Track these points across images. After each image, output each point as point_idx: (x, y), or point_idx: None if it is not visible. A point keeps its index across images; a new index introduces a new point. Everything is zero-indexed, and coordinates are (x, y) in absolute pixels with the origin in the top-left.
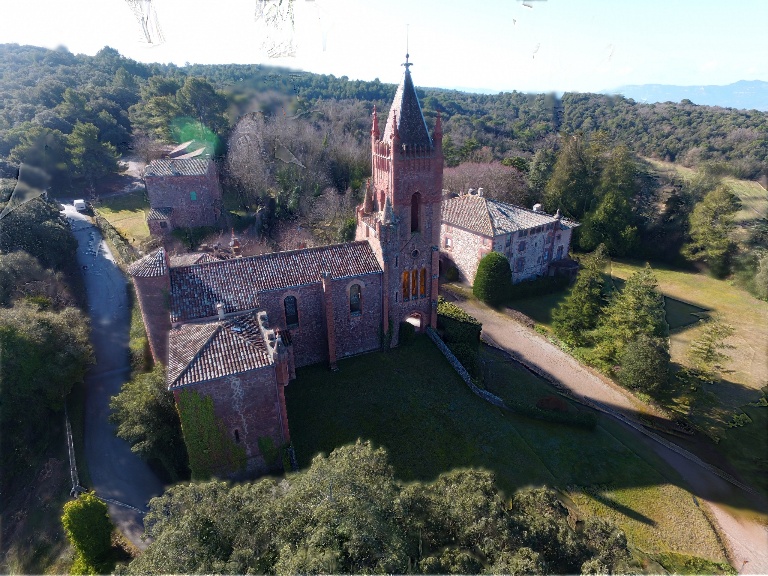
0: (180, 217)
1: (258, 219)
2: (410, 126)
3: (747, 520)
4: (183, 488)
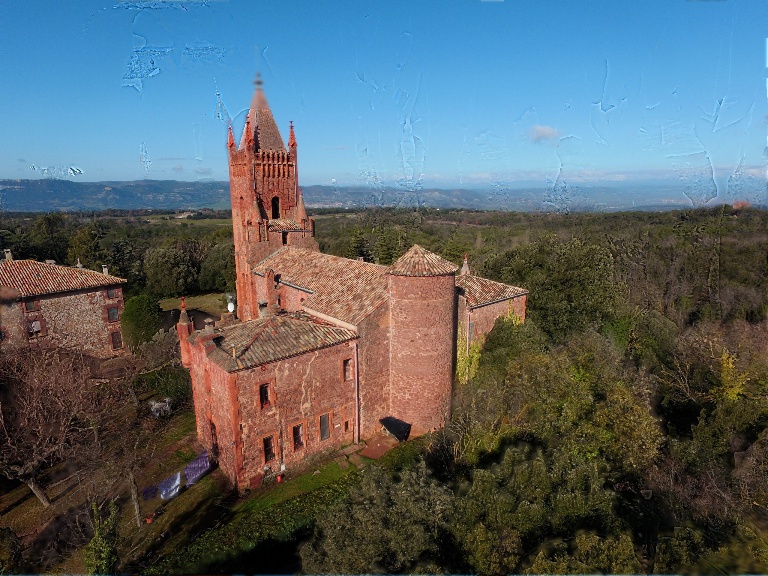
0: None
1: None
2: None
3: None
4: None
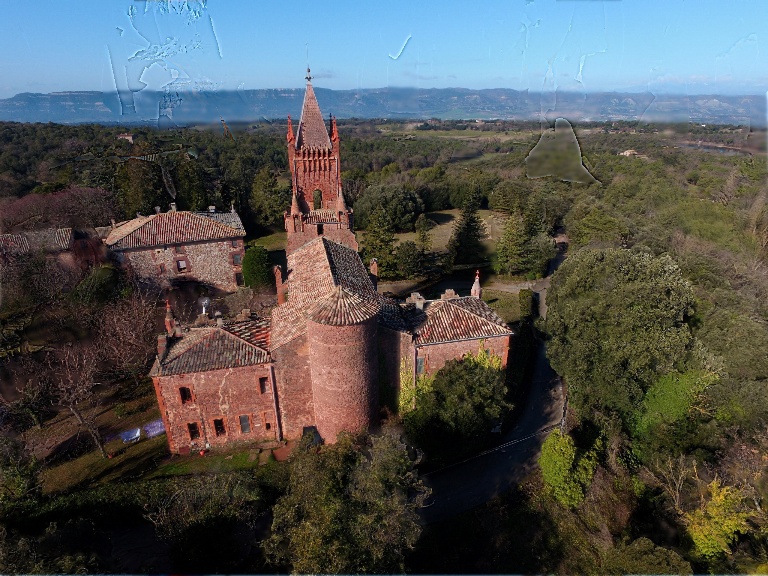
0: None
1: None
2: None
3: (491, 284)
4: None
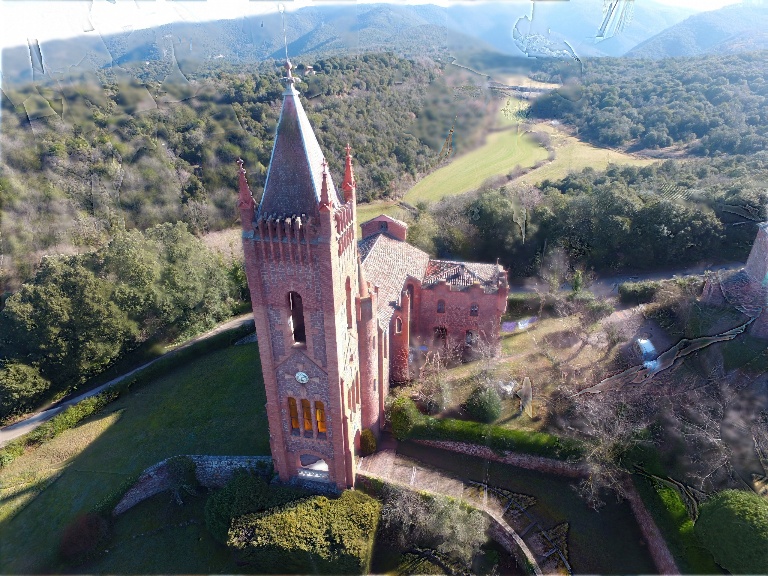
0: None
1: None
2: None
3: None
4: (181, 225)
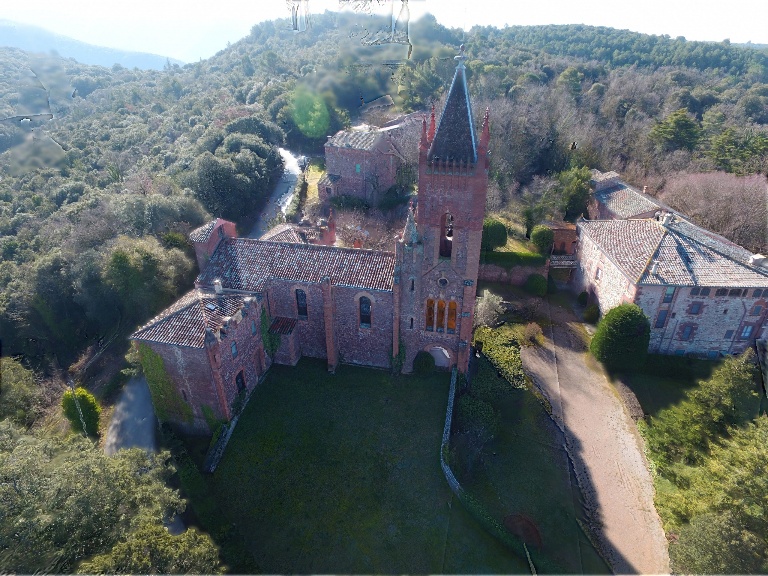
0: (346, 186)
1: (416, 199)
2: (451, 134)
3: None
4: None
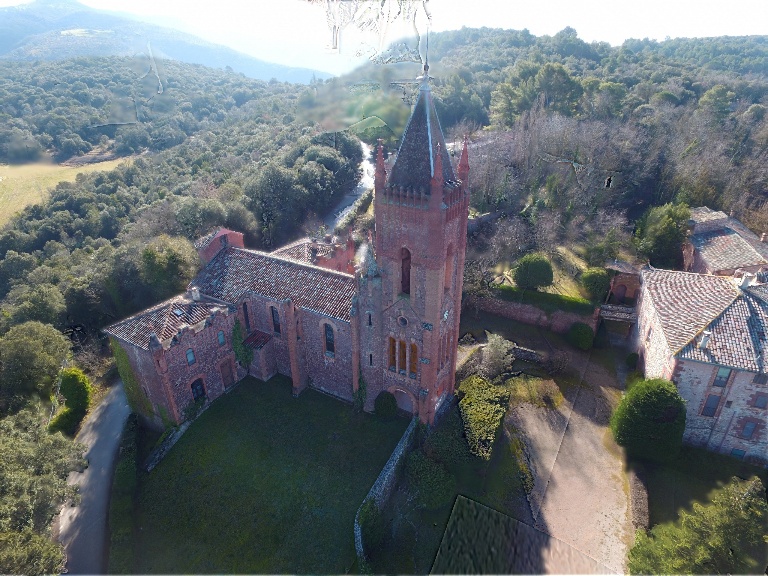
0: None
1: (472, 224)
2: (410, 162)
3: None
4: None
